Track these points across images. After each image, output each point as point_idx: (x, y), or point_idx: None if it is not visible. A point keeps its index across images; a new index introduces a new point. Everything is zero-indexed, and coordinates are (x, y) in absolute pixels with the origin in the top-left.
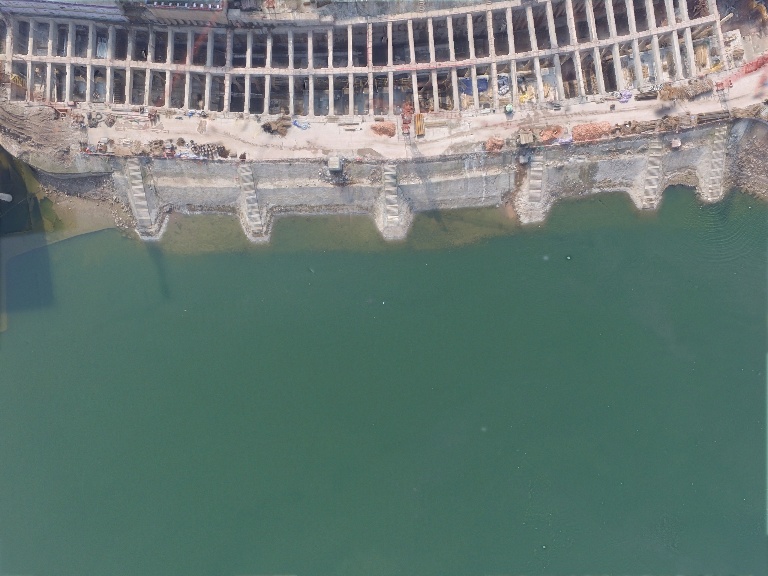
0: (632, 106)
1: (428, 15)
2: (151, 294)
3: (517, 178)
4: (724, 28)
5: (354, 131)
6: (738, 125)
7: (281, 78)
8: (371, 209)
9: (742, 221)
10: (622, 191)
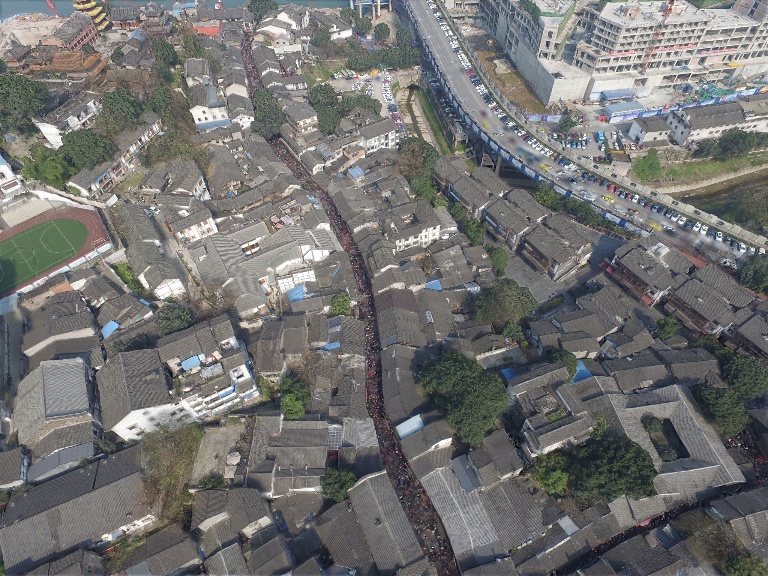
0: None
1: None
2: (301, 1)
3: None
4: None
5: None
6: None
7: None
8: None
9: None
10: None
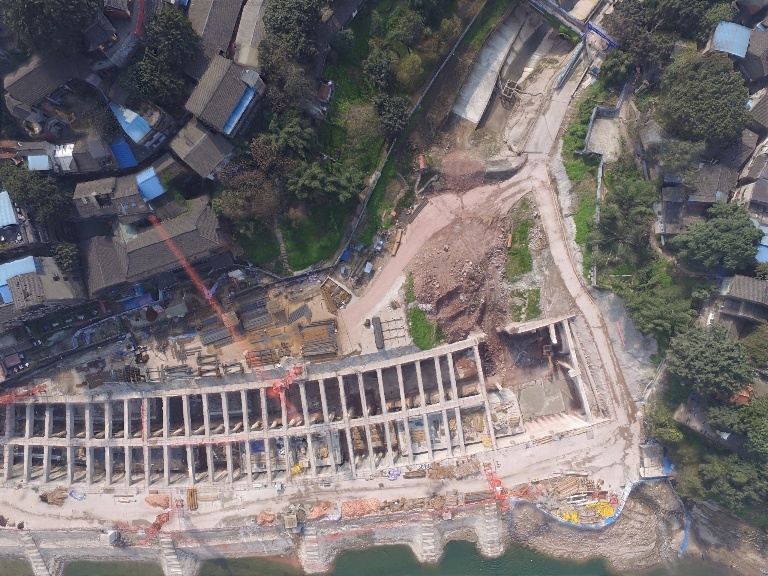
0: (401, 484)
1: (201, 391)
2: None
3: (294, 540)
4: (516, 372)
5: (129, 503)
6: (507, 501)
7: (80, 414)
8: (157, 559)
9: (523, 574)
10: (404, 544)
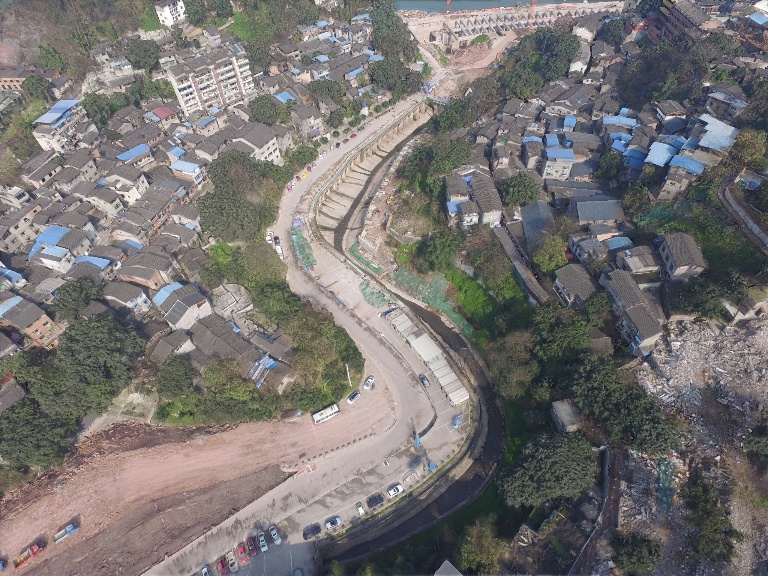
0: (479, 14)
1: None
2: None
3: None
4: None
5: None
6: None
7: None
8: None
9: None
10: None
